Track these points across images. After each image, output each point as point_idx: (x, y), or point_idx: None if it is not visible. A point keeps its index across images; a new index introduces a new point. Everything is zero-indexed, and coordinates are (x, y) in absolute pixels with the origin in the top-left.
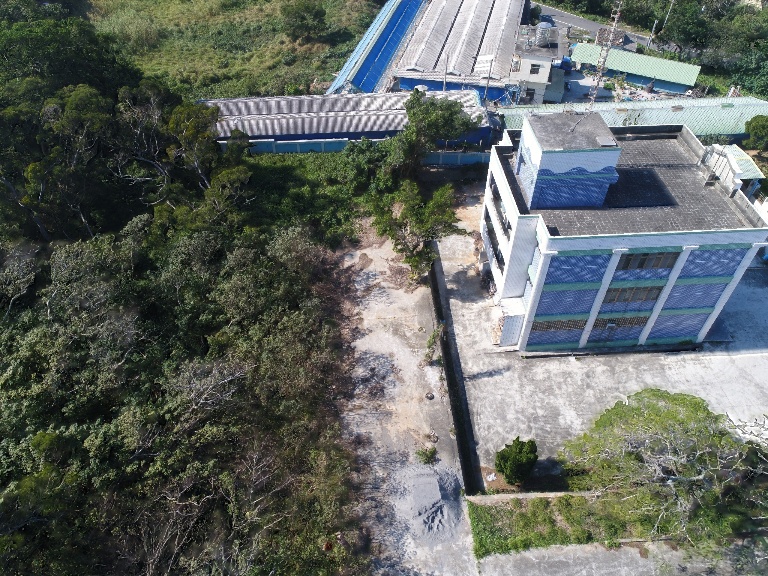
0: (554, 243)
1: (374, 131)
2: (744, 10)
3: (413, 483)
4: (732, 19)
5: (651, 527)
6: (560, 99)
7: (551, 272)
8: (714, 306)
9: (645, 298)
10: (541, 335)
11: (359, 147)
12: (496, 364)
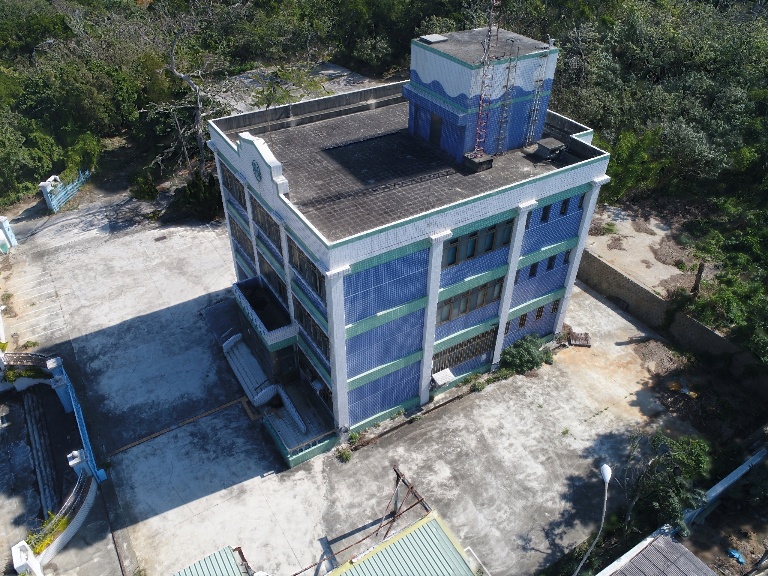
0: None
1: None
2: None
3: None
4: None
5: None
6: None
7: None
8: None
9: None
10: None
11: None
12: None
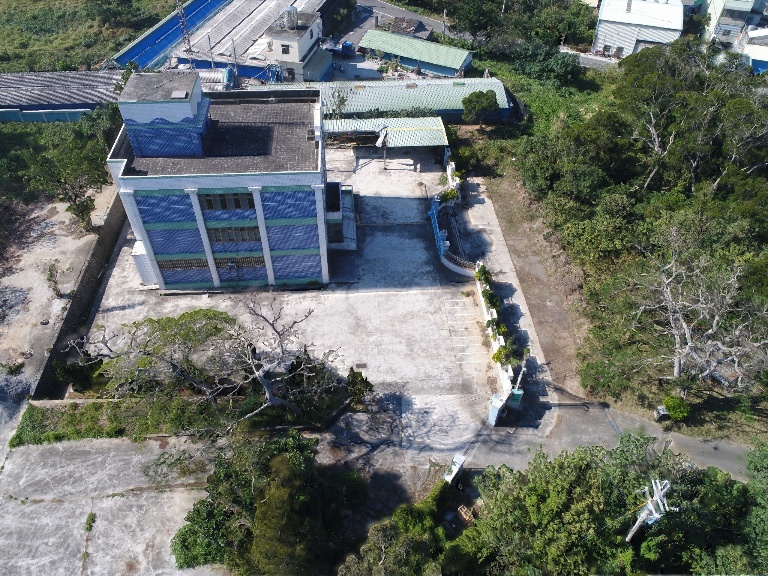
0: (126, 183)
1: (115, 102)
2: (551, 3)
3: None
4: (542, 12)
5: (178, 424)
6: (318, 78)
7: (145, 211)
8: (319, 247)
9: (249, 238)
10: (174, 274)
11: (89, 115)
12: (133, 300)
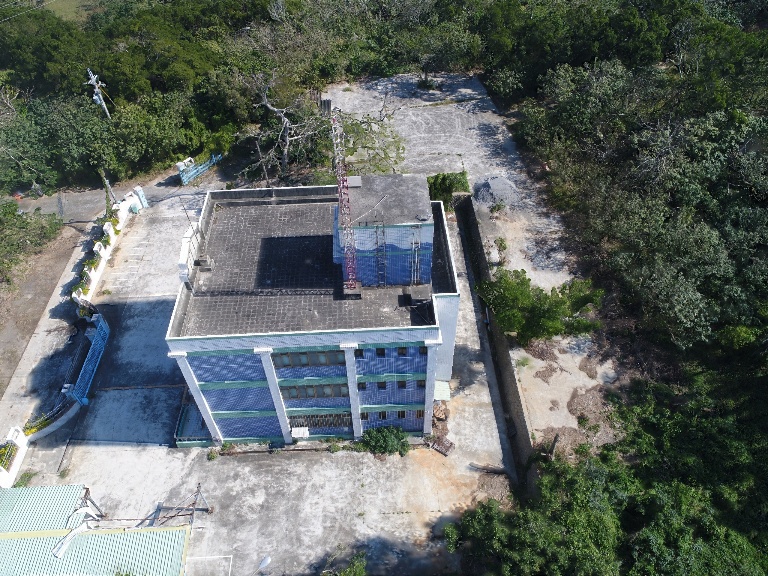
0: None
1: None
2: None
3: (506, 185)
4: None
5: None
6: None
7: None
8: None
9: None
10: None
11: None
12: None
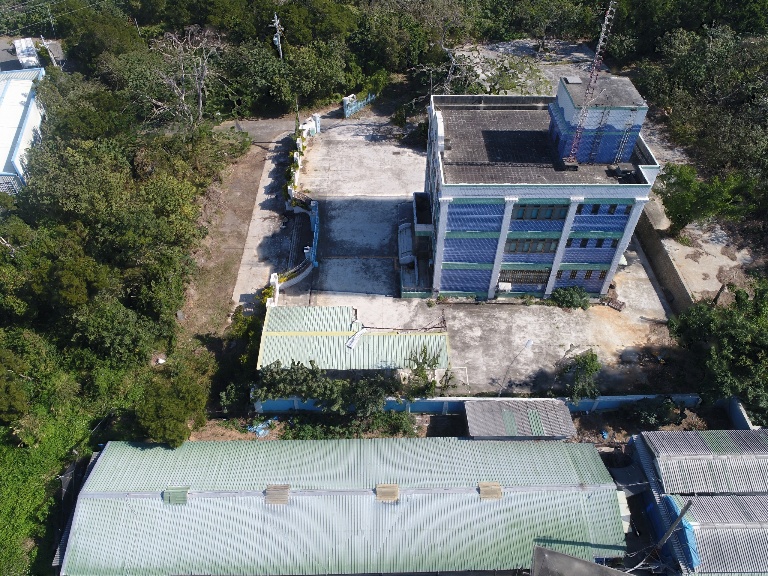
0: None
1: None
2: None
3: None
4: None
5: None
6: None
7: None
8: None
9: None
10: None
11: None
12: None
